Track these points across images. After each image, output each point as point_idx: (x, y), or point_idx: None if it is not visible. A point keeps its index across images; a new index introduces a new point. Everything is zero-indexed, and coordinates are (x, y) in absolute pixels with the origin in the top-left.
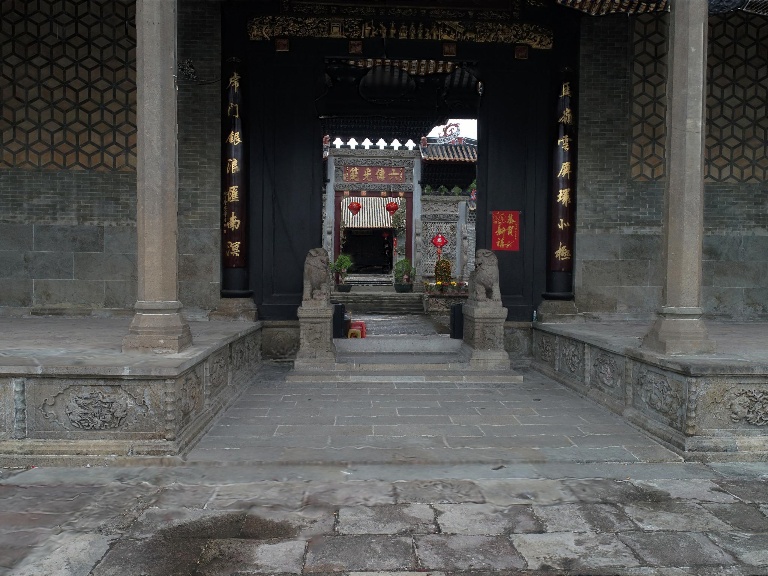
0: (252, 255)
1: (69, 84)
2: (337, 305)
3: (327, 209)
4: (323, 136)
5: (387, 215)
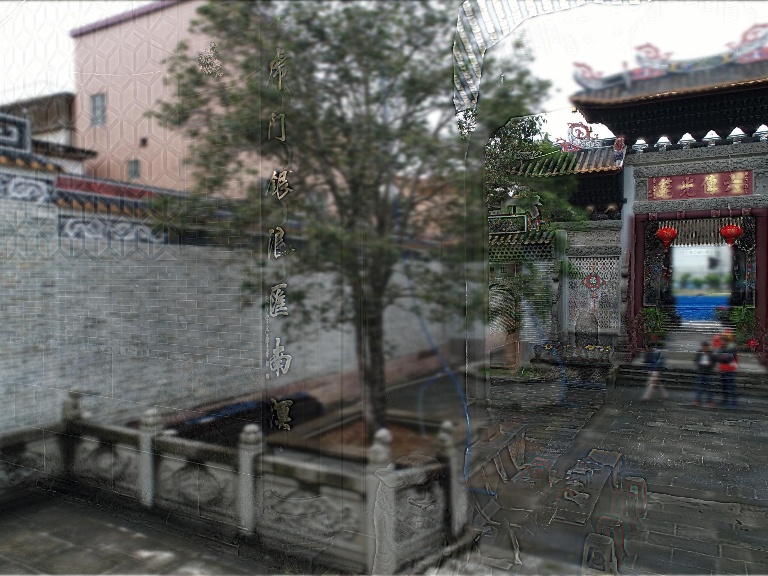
0: (324, 423)
1: (74, 125)
2: (497, 568)
3: (623, 241)
4: None
5: None
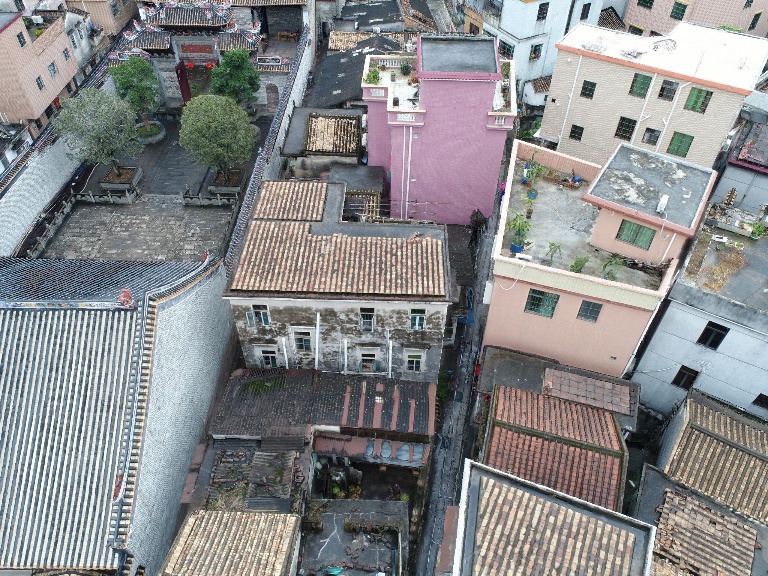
0: None
1: None
2: None
3: None
4: (220, 29)
5: (4, 266)
